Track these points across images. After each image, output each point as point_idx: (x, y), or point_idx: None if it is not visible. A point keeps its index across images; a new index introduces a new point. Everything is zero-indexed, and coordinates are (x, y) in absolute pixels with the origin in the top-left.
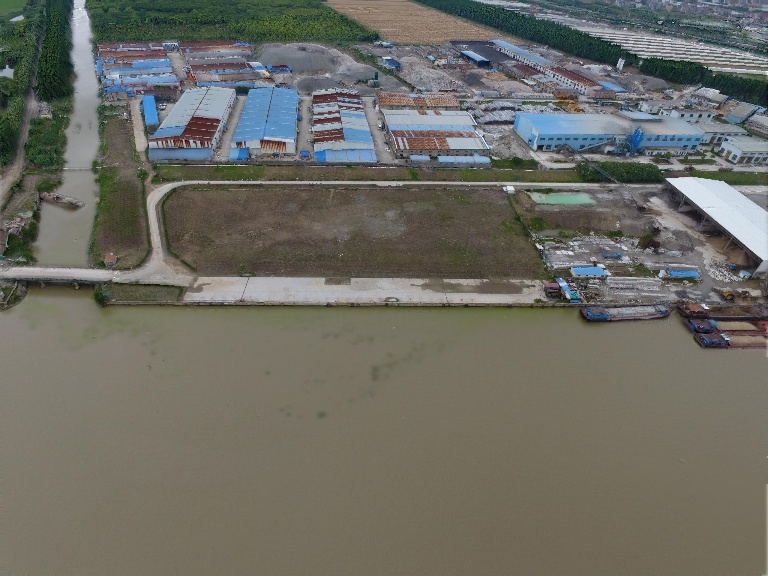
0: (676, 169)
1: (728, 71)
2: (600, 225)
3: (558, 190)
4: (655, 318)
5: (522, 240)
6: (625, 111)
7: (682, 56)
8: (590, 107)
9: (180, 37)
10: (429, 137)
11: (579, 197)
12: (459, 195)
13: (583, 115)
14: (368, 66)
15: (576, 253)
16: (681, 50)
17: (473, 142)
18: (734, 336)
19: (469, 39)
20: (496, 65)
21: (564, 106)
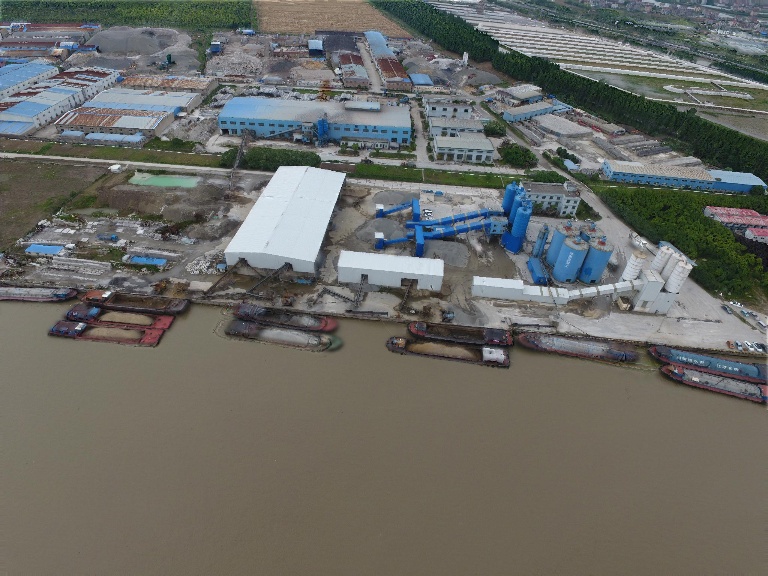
0: (351, 161)
1: (608, 71)
2: (146, 207)
3: (171, 172)
4: (49, 301)
5: (41, 216)
6: (394, 103)
7: (579, 55)
8: (368, 98)
9: (51, 19)
10: (105, 114)
11: (186, 180)
12: (57, 170)
13: (305, 102)
14: (189, 50)
15: (77, 232)
16: (591, 49)
17: (146, 121)
18: (101, 327)
19: (356, 31)
20: (328, 54)
21: (335, 95)
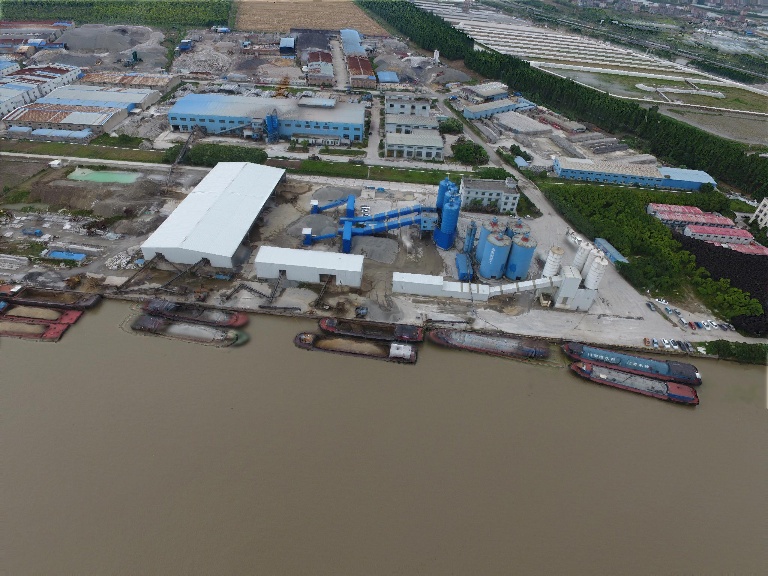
0: None
1: (582, 70)
2: (77, 203)
3: (112, 168)
4: None
5: None
6: (355, 100)
7: (556, 53)
8: (331, 95)
9: (26, 17)
10: (55, 110)
11: (126, 176)
12: None
13: (260, 98)
14: (158, 48)
15: (2, 227)
16: (570, 48)
17: (95, 117)
18: (5, 322)
19: (334, 29)
20: (299, 52)
21: None
